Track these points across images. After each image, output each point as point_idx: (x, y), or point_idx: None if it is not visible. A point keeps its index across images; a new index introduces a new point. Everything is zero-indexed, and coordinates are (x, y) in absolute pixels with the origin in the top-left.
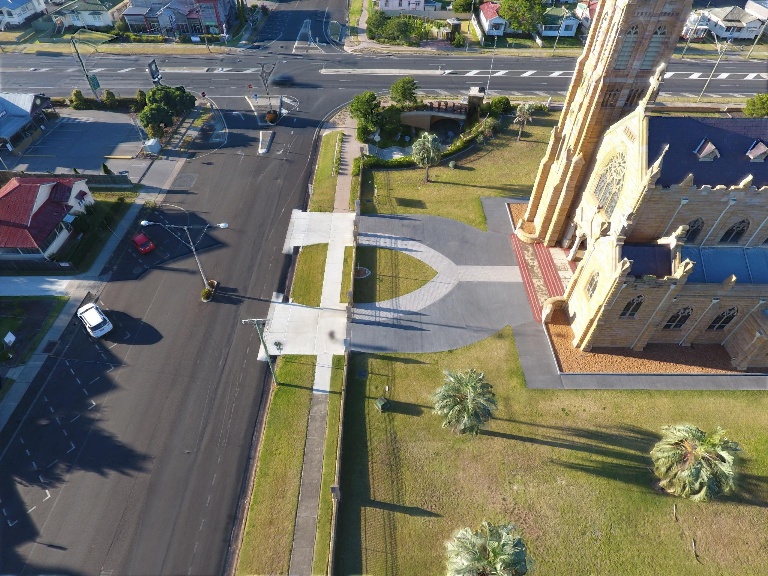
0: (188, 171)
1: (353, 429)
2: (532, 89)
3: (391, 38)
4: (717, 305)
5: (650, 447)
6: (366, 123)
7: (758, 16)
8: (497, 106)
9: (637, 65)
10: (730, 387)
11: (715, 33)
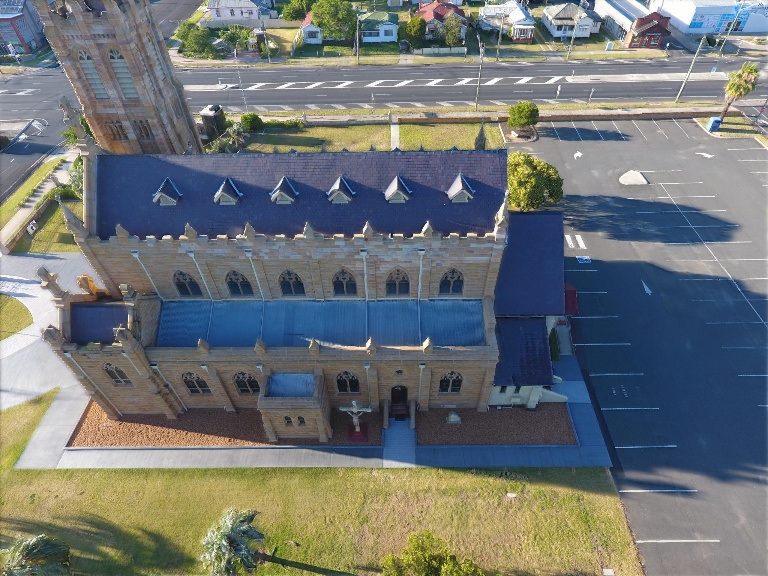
0: None
1: None
2: (306, 102)
3: (198, 51)
4: (213, 371)
5: (97, 545)
6: None
7: (603, 12)
8: (244, 124)
9: (113, 94)
10: (244, 464)
11: (550, 32)
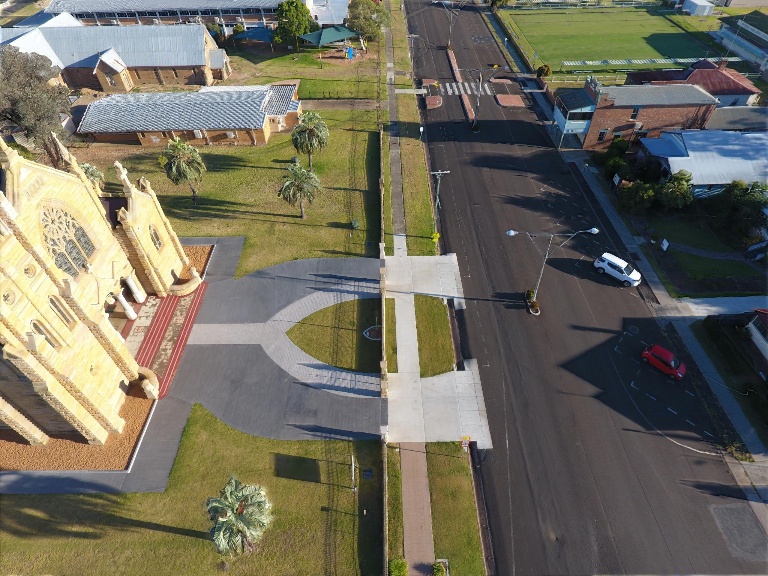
0: (767, 570)
1: (374, 216)
2: None
3: None
4: None
5: (185, 213)
6: None
7: None
8: None
9: None
10: None
11: None
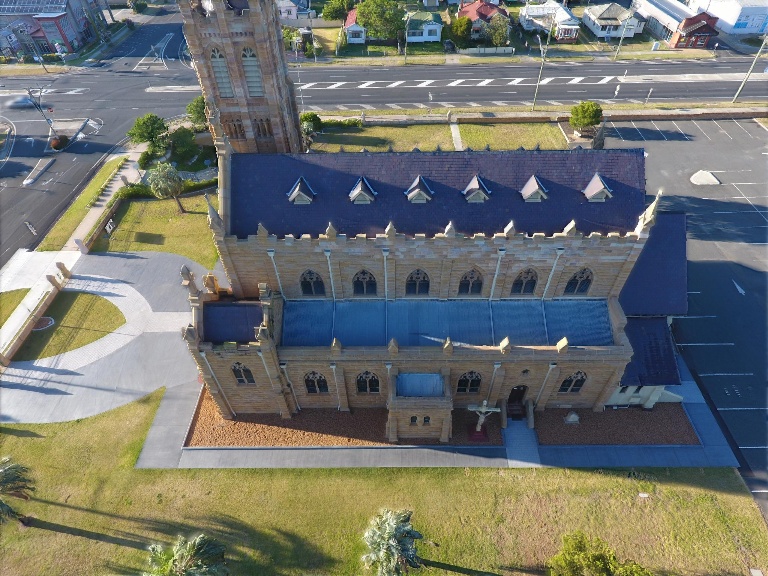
0: None
1: None
2: (360, 102)
3: None
4: (340, 370)
5: (233, 545)
6: (156, 147)
7: (644, 12)
8: None
9: (240, 92)
10: (368, 464)
11: (593, 32)
